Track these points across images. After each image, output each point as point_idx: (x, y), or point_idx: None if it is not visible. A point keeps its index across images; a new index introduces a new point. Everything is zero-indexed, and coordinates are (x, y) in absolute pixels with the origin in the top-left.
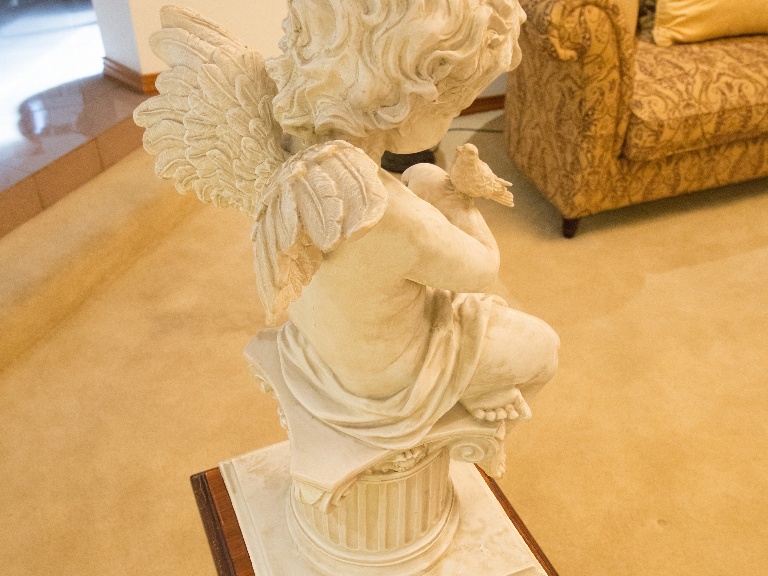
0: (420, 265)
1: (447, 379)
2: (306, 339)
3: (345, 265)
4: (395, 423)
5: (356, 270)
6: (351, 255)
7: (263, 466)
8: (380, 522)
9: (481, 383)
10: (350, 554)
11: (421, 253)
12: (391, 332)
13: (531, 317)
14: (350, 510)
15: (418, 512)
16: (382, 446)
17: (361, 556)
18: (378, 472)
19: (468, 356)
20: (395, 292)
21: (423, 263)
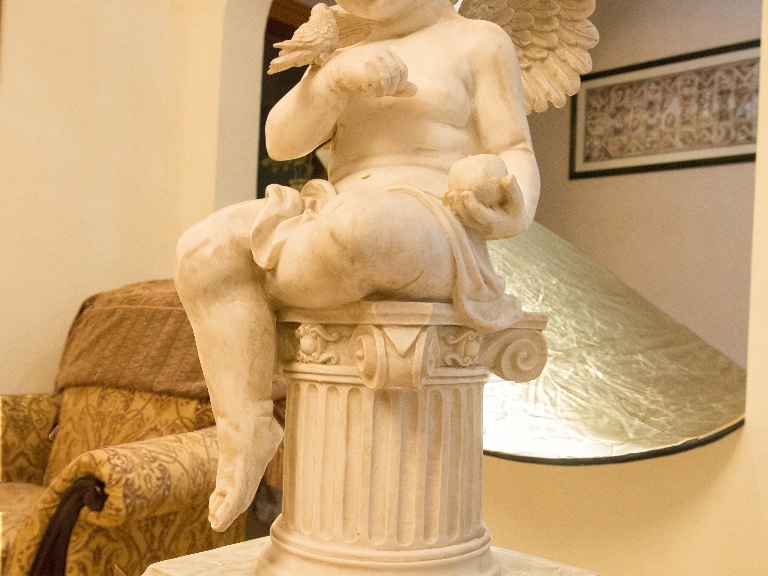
0: None
1: None
2: None
3: None
4: None
5: None
6: None
7: (552, 571)
8: None
9: None
10: None
11: None
12: None
13: (220, 211)
14: None
15: None
16: None
17: None
18: None
19: None
20: None
21: None
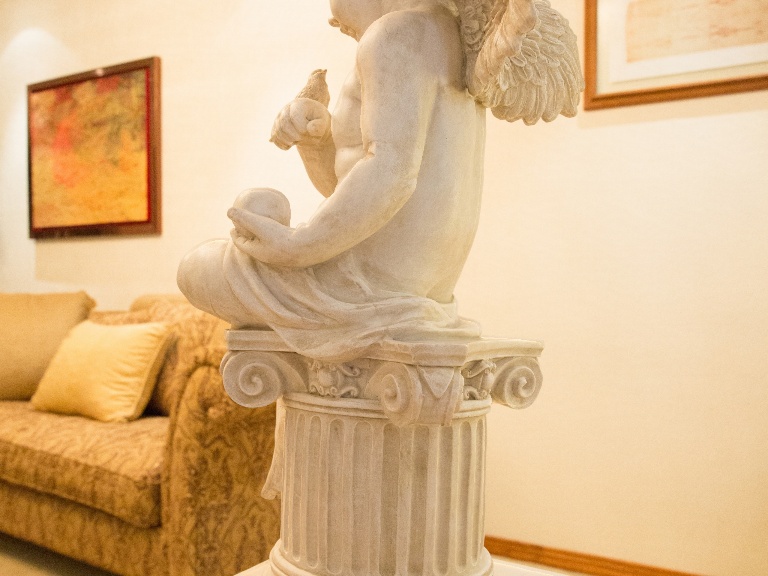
0: None
1: None
2: None
3: None
4: None
5: None
6: None
7: None
8: None
9: None
10: None
11: None
12: None
13: None
14: None
15: None
16: None
17: None
18: None
19: None
20: None
21: None
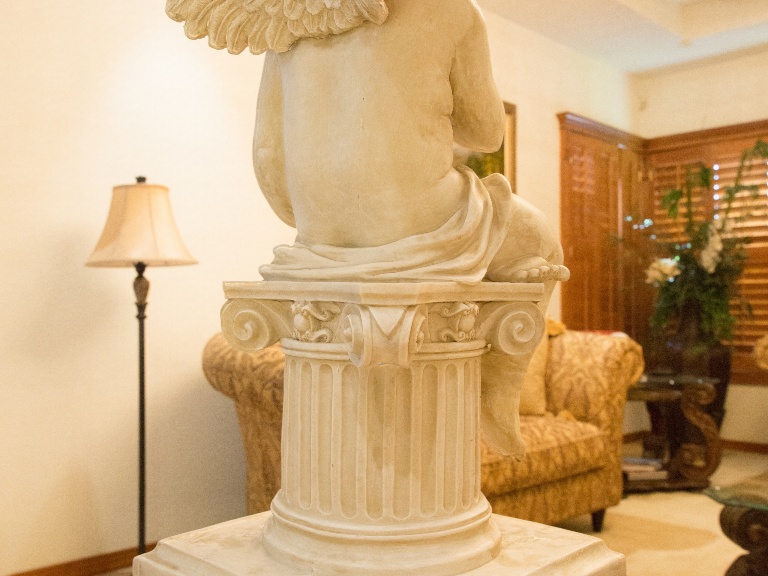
0: (472, 32)
1: (492, 210)
2: (326, 202)
3: (408, 22)
4: (452, 259)
5: (419, 27)
6: (414, 10)
7: (209, 537)
8: (438, 445)
9: (516, 234)
10: (400, 525)
11: (474, 16)
12: (441, 133)
13: None
14: (399, 433)
15: (473, 442)
16: (447, 278)
17: (416, 524)
18: (436, 342)
19: (502, 196)
20: (446, 75)
21: (475, 30)
